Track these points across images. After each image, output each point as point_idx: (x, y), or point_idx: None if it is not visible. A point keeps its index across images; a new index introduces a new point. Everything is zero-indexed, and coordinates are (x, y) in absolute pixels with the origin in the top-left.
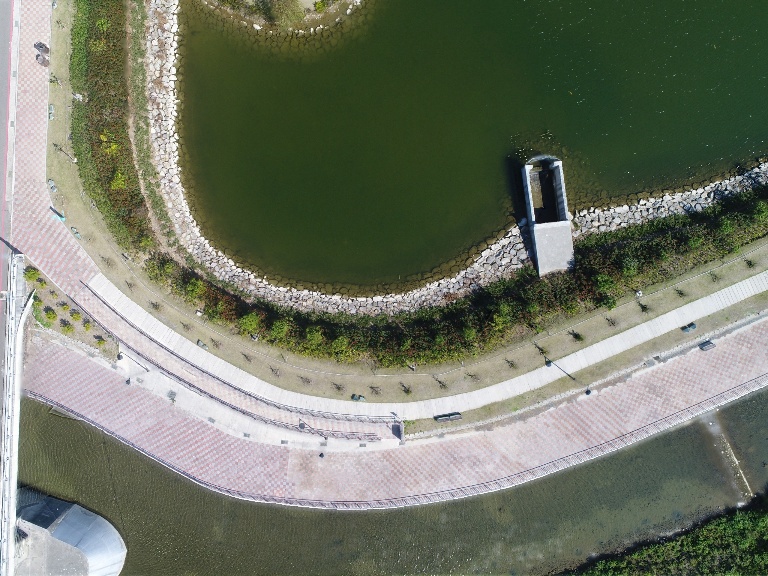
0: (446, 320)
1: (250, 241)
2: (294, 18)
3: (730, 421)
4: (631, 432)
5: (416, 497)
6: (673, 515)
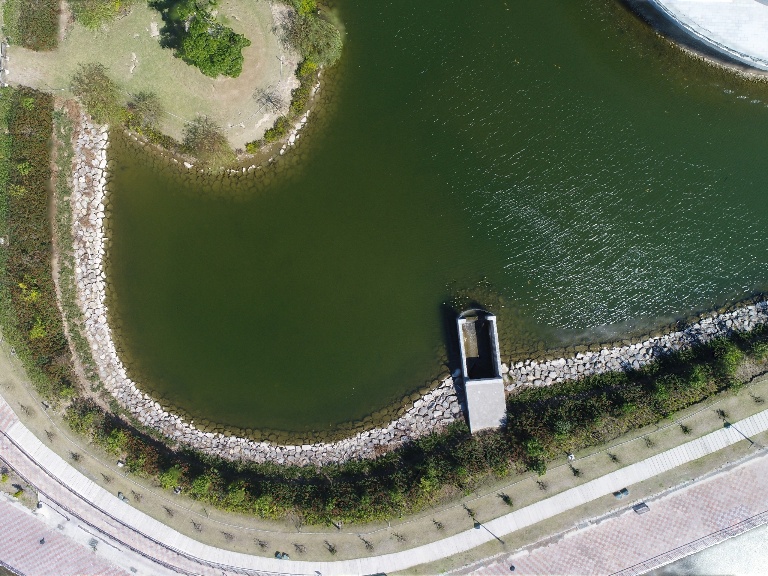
0: (374, 476)
1: (178, 382)
2: (225, 158)
3: (668, 575)
4: None
5: None
6: None
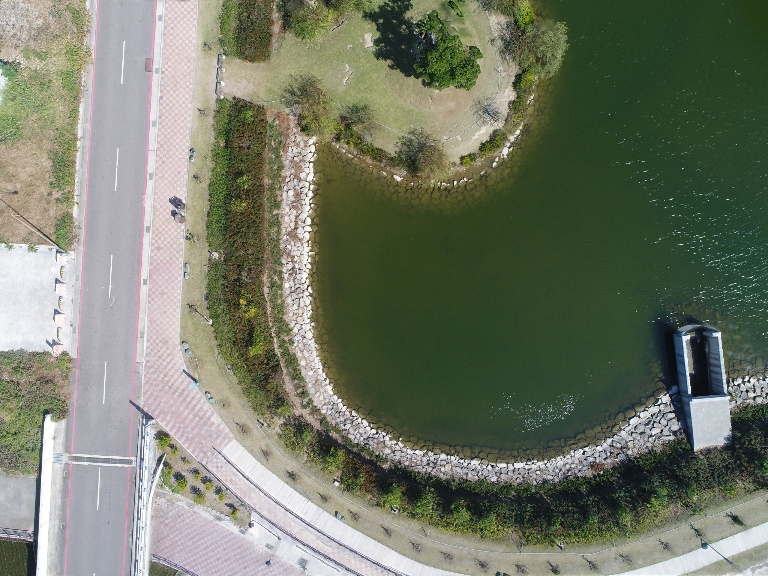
0: (595, 495)
1: (383, 399)
2: (438, 171)
3: None
4: None
5: None
6: None
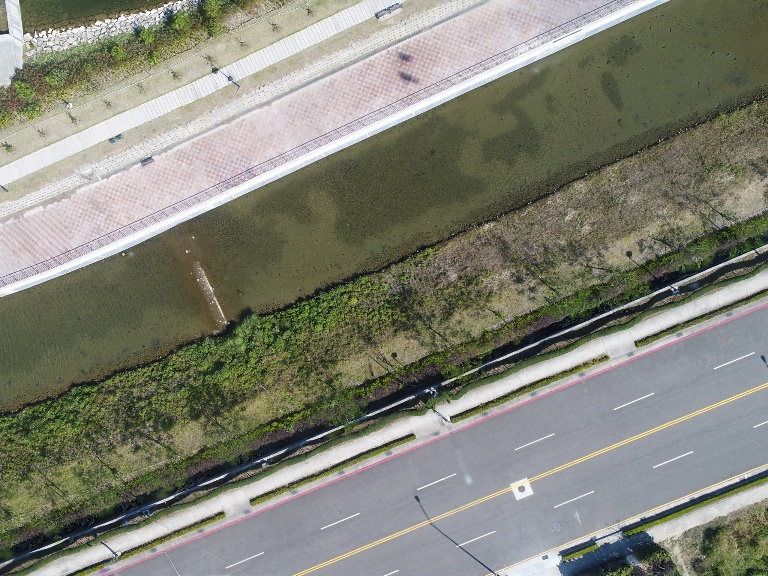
0: None
1: None
2: None
3: (206, 249)
4: (75, 248)
5: None
6: (152, 343)
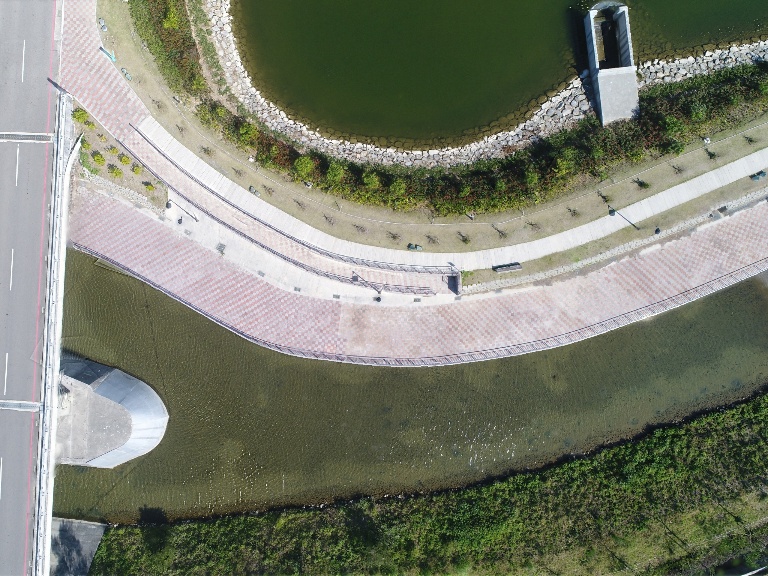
0: (506, 170)
1: (302, 95)
2: None
3: None
4: (695, 288)
5: (471, 354)
6: (733, 384)
